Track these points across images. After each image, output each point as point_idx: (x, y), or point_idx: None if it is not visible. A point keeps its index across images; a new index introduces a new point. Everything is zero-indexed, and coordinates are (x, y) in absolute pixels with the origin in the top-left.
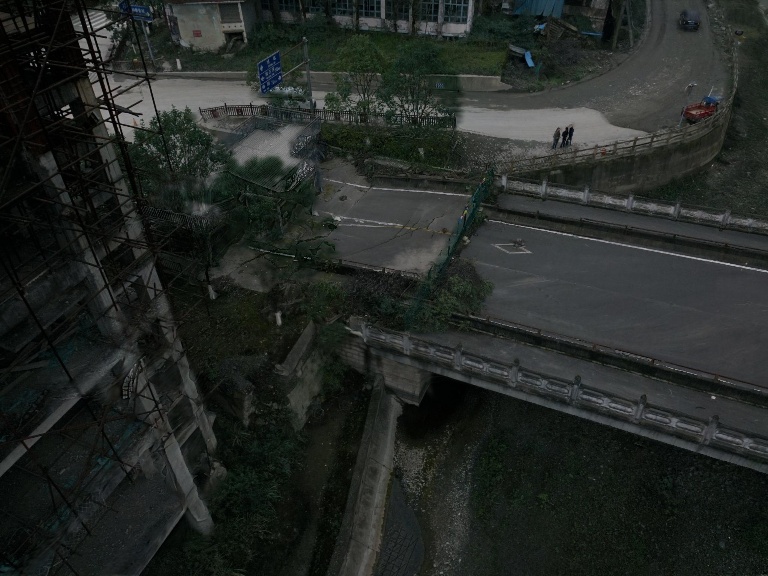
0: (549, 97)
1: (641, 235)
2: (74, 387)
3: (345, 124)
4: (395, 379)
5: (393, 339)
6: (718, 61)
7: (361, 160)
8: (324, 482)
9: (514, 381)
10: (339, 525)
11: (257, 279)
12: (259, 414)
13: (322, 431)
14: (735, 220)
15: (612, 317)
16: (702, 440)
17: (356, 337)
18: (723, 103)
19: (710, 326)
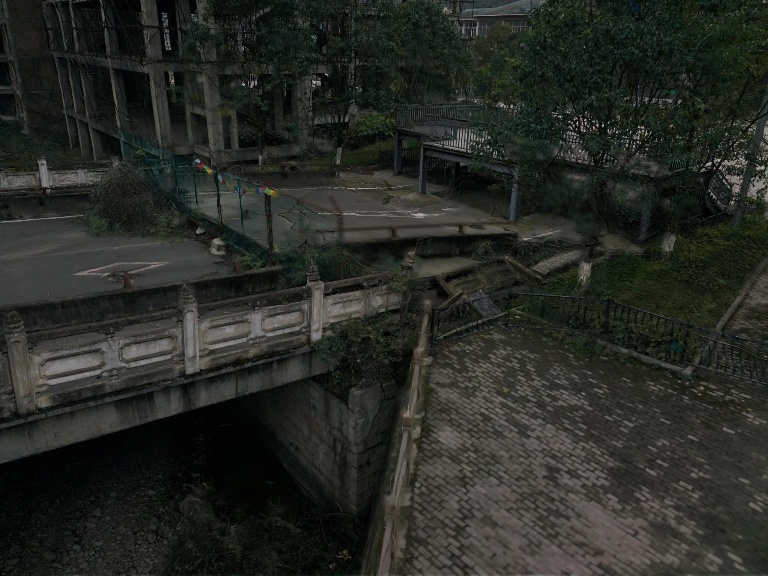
0: None
1: None
2: (298, 138)
3: None
4: None
5: None
6: None
7: None
8: None
9: None
10: None
11: (343, 175)
12: None
13: None
14: None
15: None
16: None
17: None
18: None
19: None
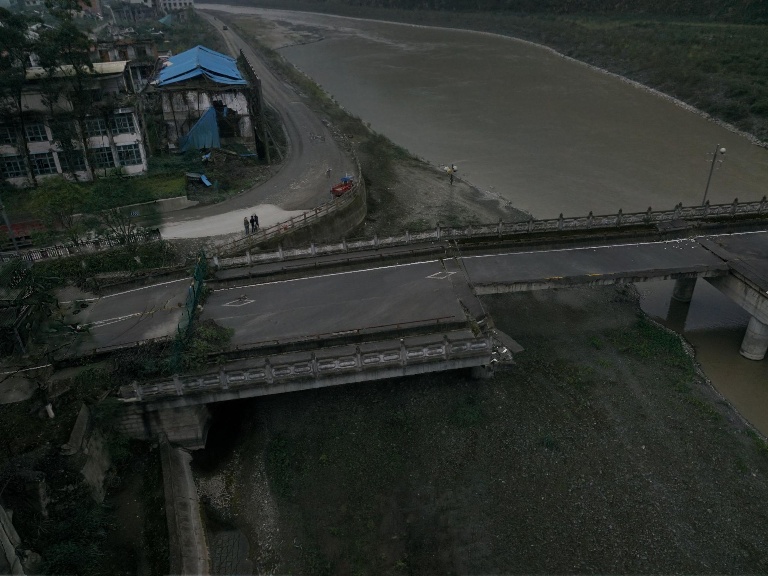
0: (231, 203)
1: (327, 266)
2: None
3: (54, 259)
4: (177, 431)
5: (165, 386)
6: (345, 157)
7: (83, 280)
8: (141, 528)
9: (271, 378)
10: (167, 548)
11: (13, 393)
12: (56, 502)
13: (124, 495)
14: (382, 241)
15: (325, 320)
16: (402, 363)
17: (130, 405)
18: (355, 180)
19: (387, 303)
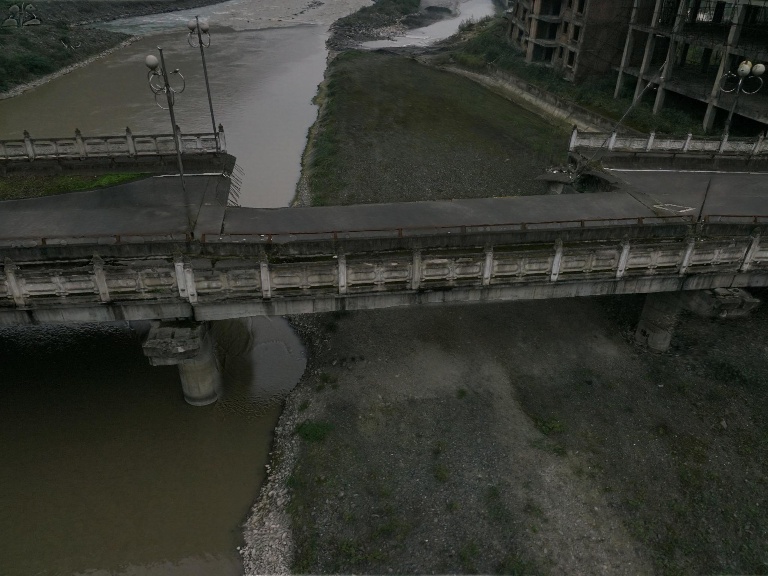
0: None
1: None
2: None
3: None
4: None
5: None
6: None
7: None
8: None
9: None
10: None
11: None
12: None
13: None
14: None
15: None
16: None
17: None
18: None
19: (718, 190)
